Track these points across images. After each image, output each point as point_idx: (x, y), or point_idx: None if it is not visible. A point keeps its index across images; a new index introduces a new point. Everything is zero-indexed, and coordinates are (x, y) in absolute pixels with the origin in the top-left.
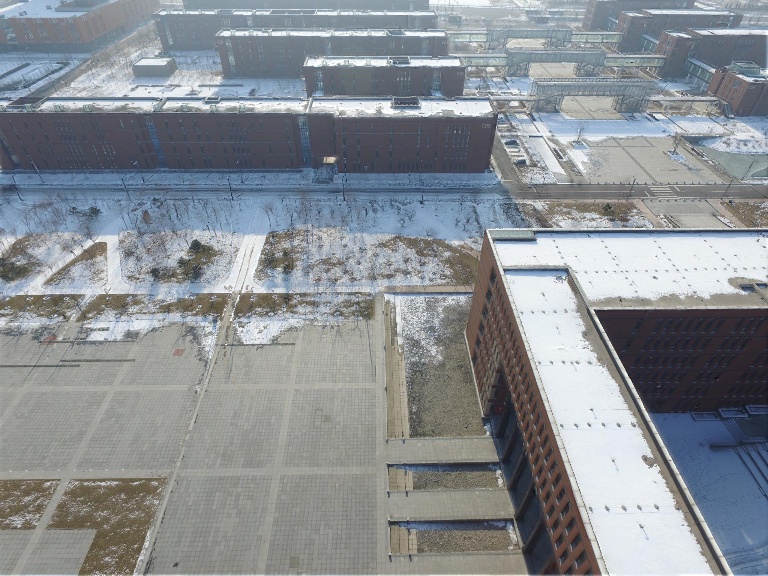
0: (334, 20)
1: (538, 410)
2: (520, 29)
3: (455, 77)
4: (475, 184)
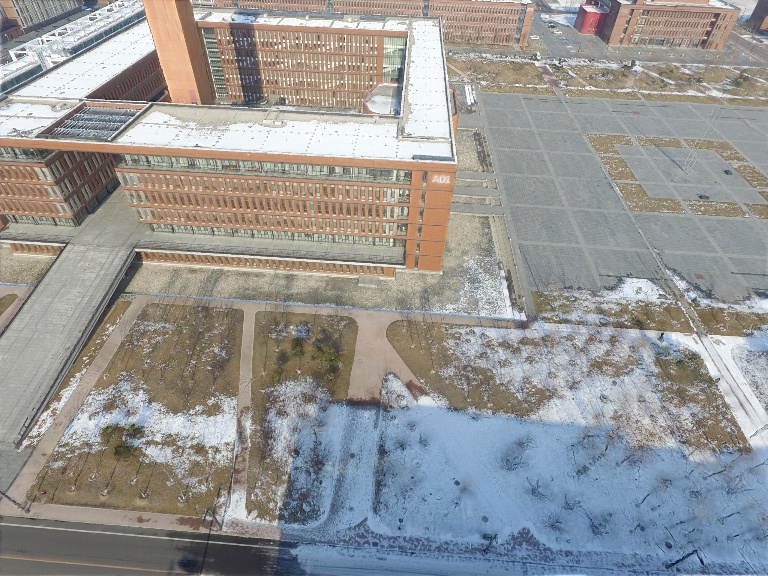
0: None
1: None
2: None
3: None
4: None
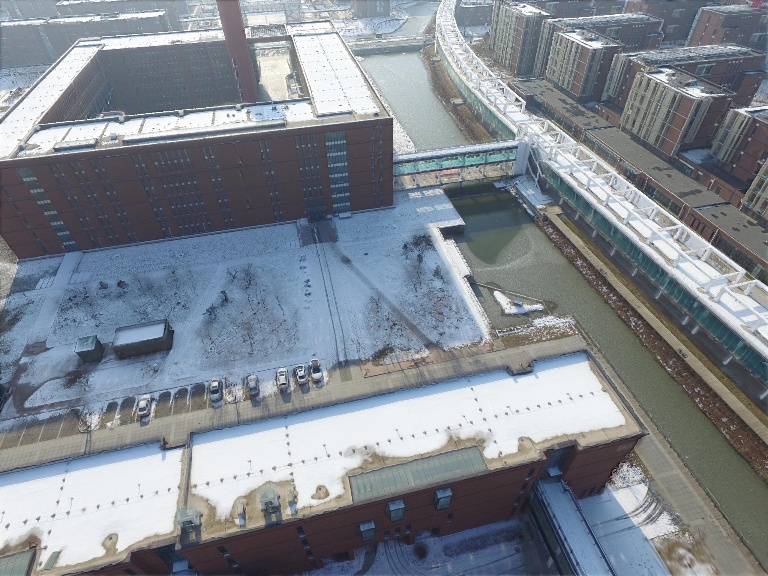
0: None
1: None
2: None
3: (165, 5)
4: None
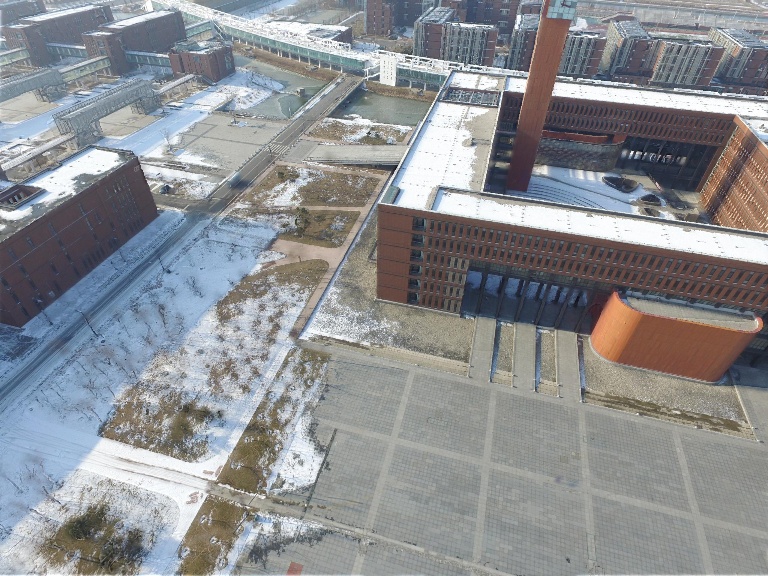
0: None
1: (551, 241)
2: None
3: None
4: (171, 227)
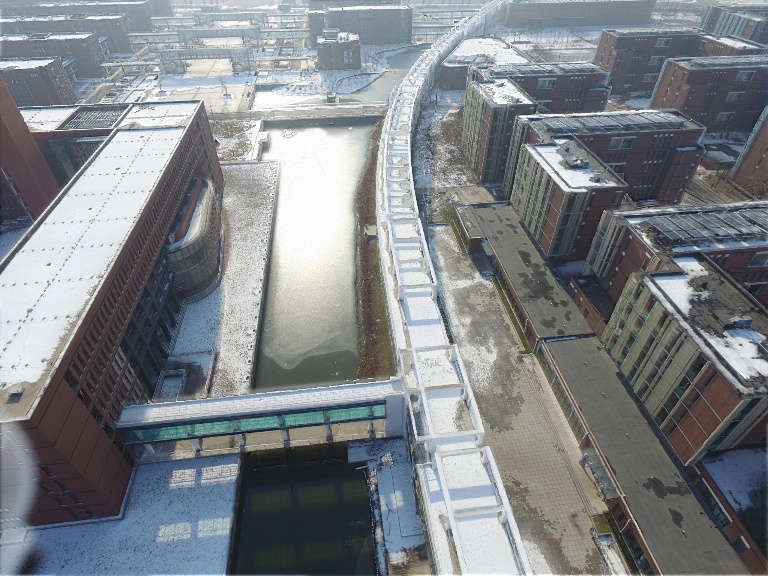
0: (52, 10)
1: None
2: (221, 13)
3: (81, 47)
4: None
